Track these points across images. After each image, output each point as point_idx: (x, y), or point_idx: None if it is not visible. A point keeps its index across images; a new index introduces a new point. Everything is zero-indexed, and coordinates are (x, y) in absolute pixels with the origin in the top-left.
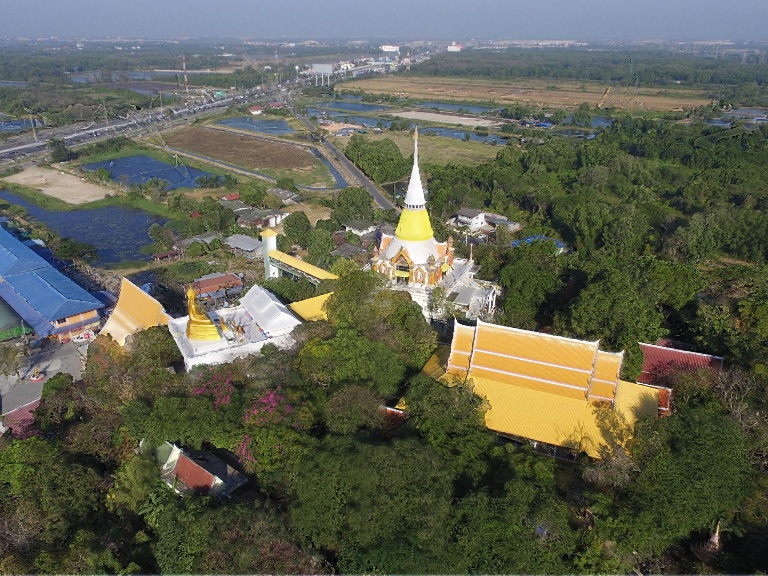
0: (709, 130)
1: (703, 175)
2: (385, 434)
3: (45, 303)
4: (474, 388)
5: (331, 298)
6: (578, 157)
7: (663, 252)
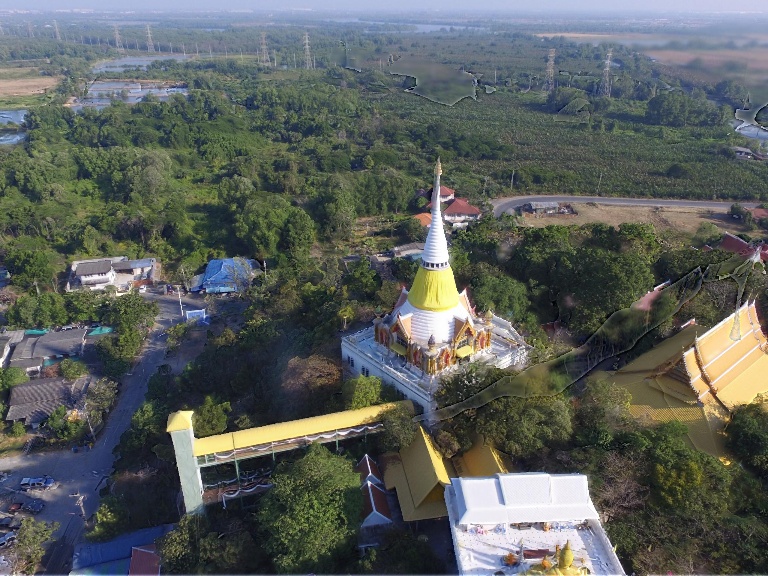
0: (140, 108)
1: (211, 153)
2: None
3: None
4: (731, 401)
5: (449, 433)
6: (77, 163)
7: (328, 232)
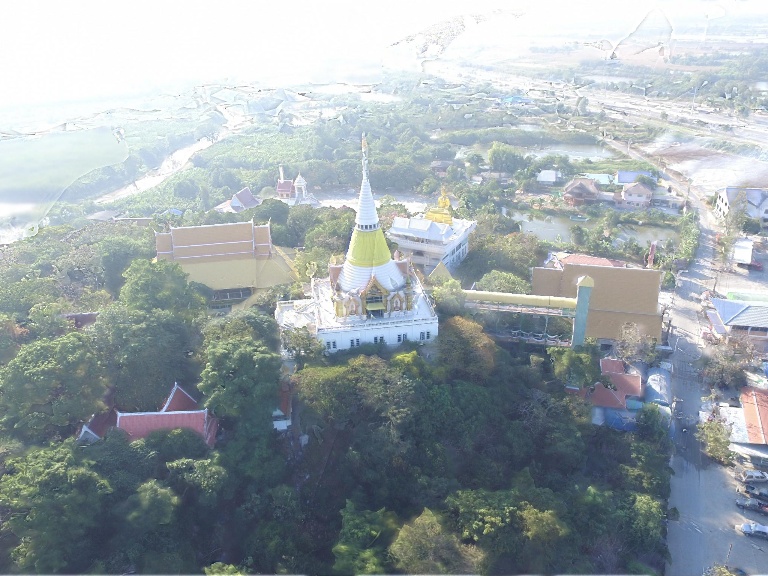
0: None
1: None
2: (293, 239)
3: (760, 302)
4: None
5: None
6: None
7: None
